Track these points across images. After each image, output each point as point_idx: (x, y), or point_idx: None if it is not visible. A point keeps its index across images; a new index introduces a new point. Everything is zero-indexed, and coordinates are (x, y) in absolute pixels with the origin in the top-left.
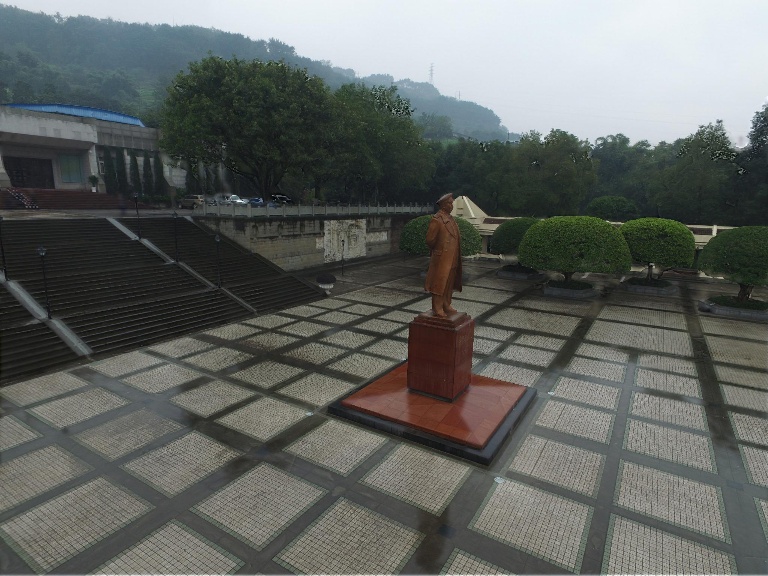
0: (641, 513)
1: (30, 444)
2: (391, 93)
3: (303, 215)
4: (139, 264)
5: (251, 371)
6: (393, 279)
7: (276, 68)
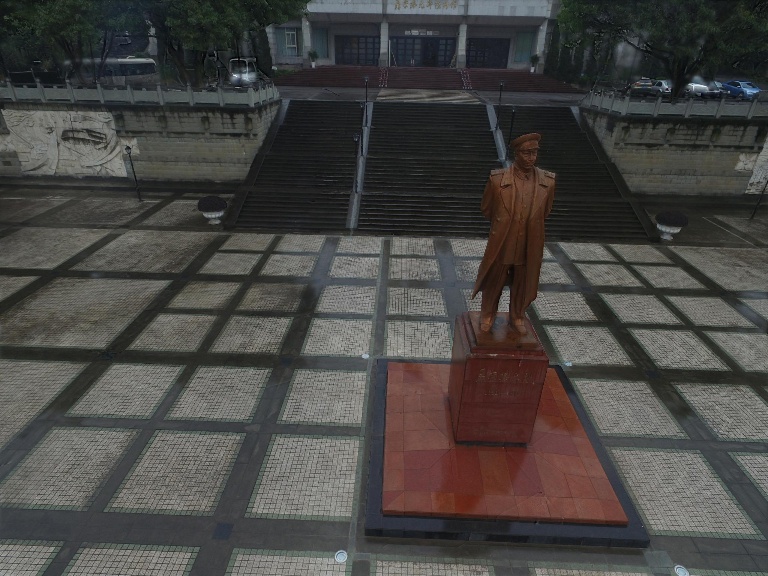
0: None
1: (238, 277)
2: None
3: (726, 116)
4: (472, 156)
5: (409, 292)
6: None
7: None
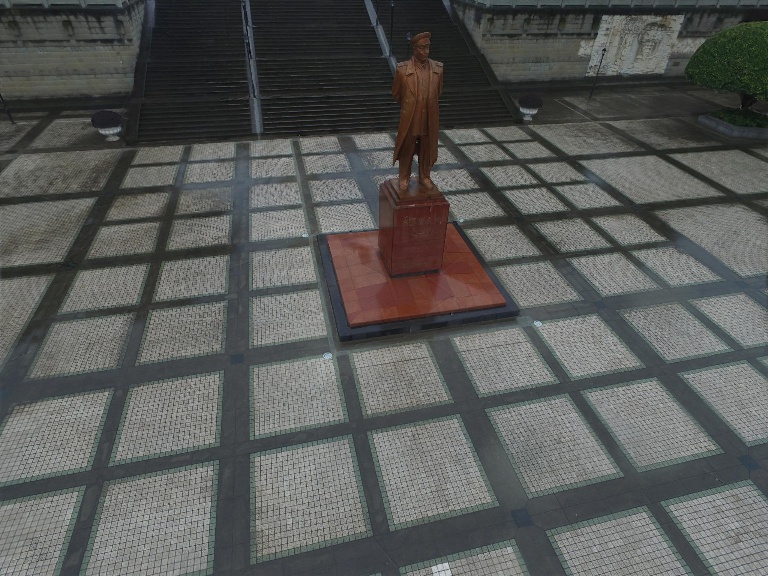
0: (373, 453)
1: (163, 187)
2: None
3: (570, 6)
4: (359, 54)
5: (328, 183)
6: (647, 117)
7: None
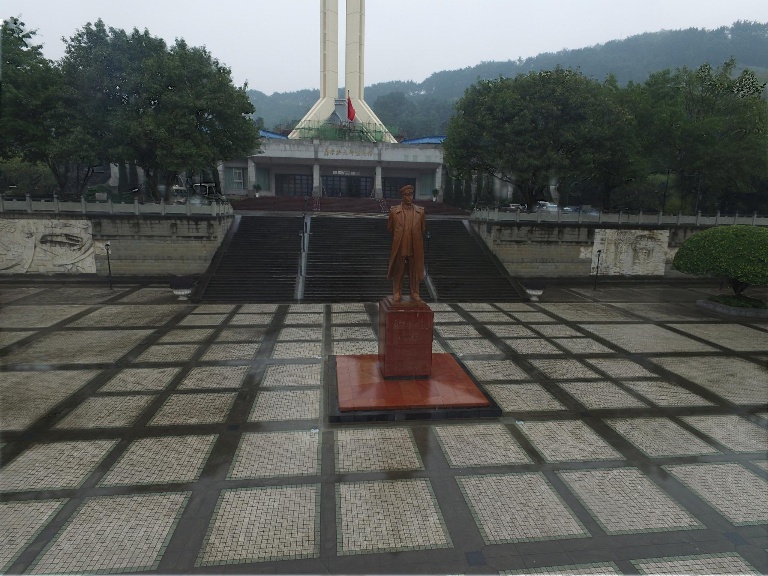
0: (337, 498)
1: (211, 326)
2: (726, 70)
3: (565, 222)
4: None
5: (348, 329)
6: (648, 301)
7: (533, 78)
